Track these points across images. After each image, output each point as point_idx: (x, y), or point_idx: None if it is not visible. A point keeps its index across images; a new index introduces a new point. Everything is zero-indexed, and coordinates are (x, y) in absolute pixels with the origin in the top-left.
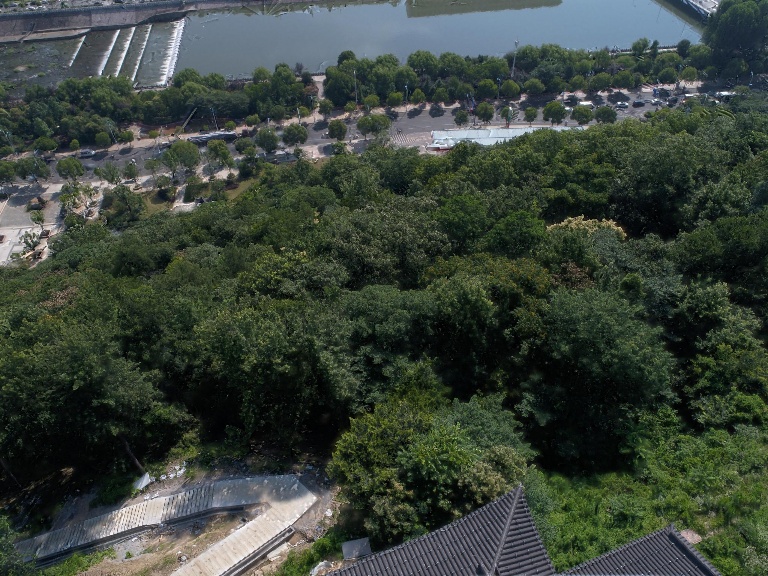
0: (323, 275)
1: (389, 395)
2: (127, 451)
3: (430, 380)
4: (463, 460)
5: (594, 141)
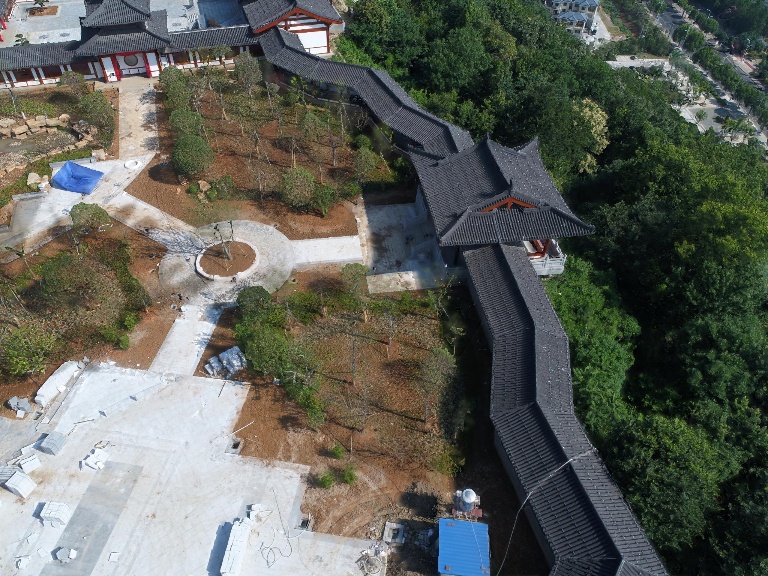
0: (498, 5)
1: (424, 17)
2: (415, 4)
3: (433, 26)
4: (379, 0)
5: (737, 148)
